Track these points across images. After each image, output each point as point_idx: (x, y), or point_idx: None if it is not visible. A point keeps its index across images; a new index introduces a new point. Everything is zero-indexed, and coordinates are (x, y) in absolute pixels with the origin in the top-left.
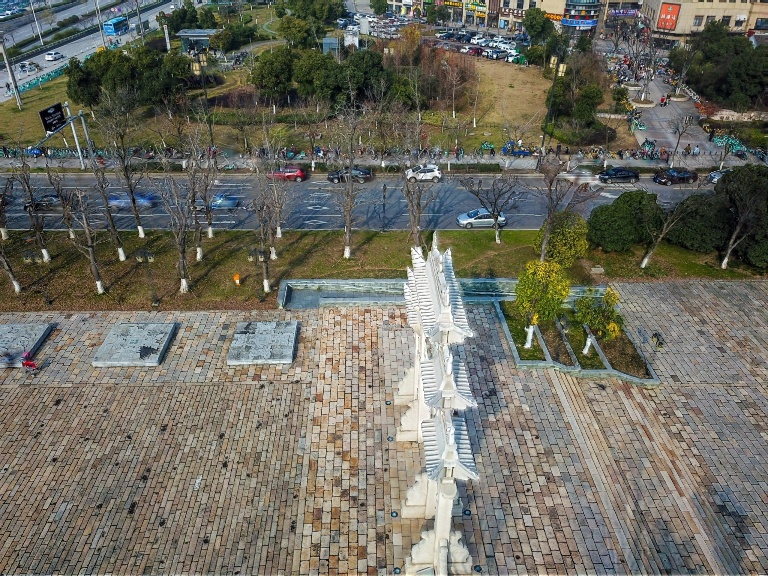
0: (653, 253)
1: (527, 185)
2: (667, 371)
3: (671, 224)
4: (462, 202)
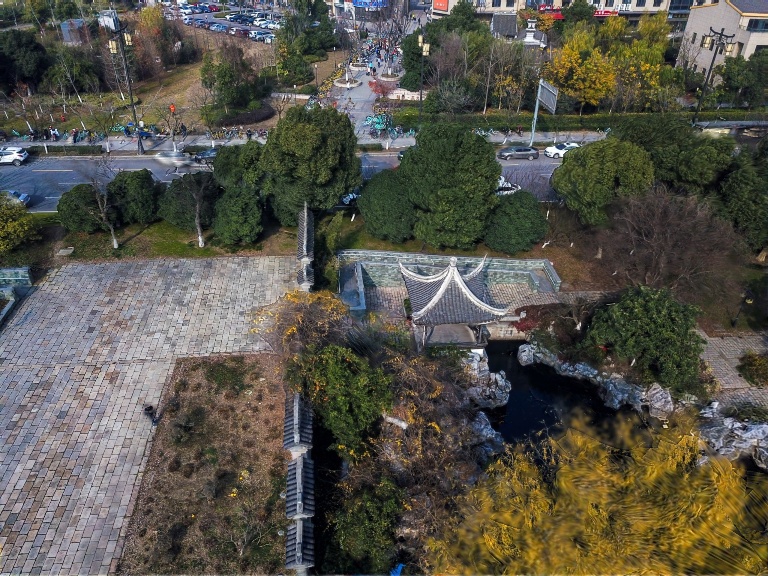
0: (145, 233)
1: (113, 167)
2: (1, 354)
3: (105, 202)
4: (18, 185)
